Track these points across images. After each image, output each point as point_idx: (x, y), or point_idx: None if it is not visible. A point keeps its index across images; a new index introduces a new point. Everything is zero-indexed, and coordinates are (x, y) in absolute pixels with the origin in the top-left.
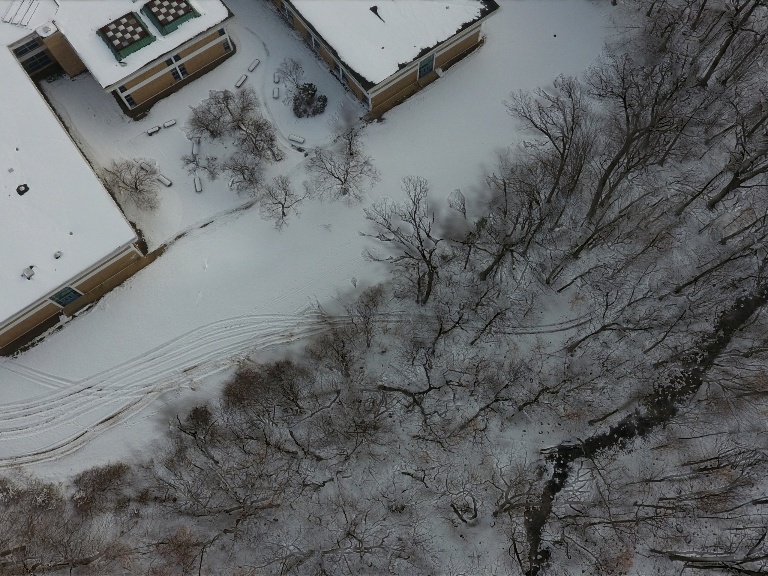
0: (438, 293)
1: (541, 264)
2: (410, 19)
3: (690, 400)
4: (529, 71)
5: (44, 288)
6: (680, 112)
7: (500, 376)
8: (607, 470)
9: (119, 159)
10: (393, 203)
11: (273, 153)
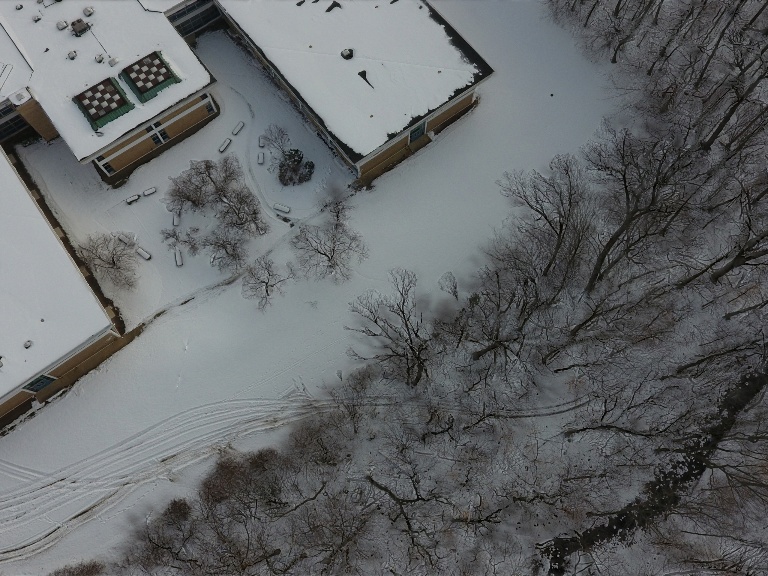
0: (429, 376)
1: (537, 344)
2: (400, 85)
3: (693, 488)
4: (525, 134)
5: (13, 381)
6: (682, 178)
7: (494, 466)
8: (606, 565)
9: (95, 233)
10: (380, 296)
11: (257, 226)
